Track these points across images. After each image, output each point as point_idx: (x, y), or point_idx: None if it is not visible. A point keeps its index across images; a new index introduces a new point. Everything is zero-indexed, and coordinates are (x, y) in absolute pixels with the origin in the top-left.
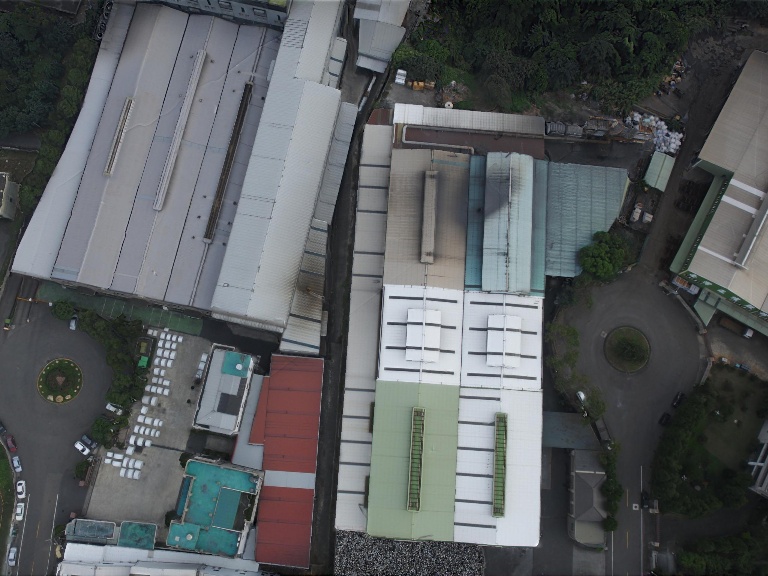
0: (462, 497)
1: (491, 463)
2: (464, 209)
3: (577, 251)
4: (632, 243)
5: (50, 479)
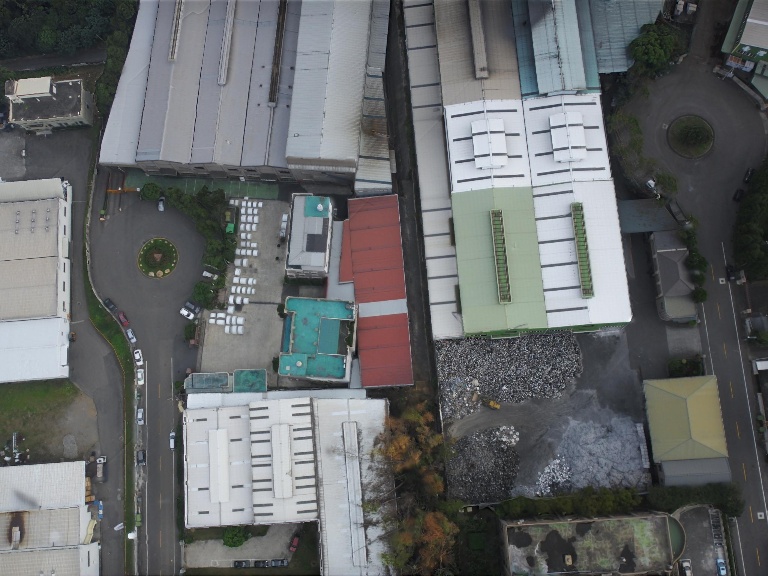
0: (550, 286)
1: (573, 251)
2: (510, 25)
3: (626, 46)
4: (680, 34)
5: (163, 345)
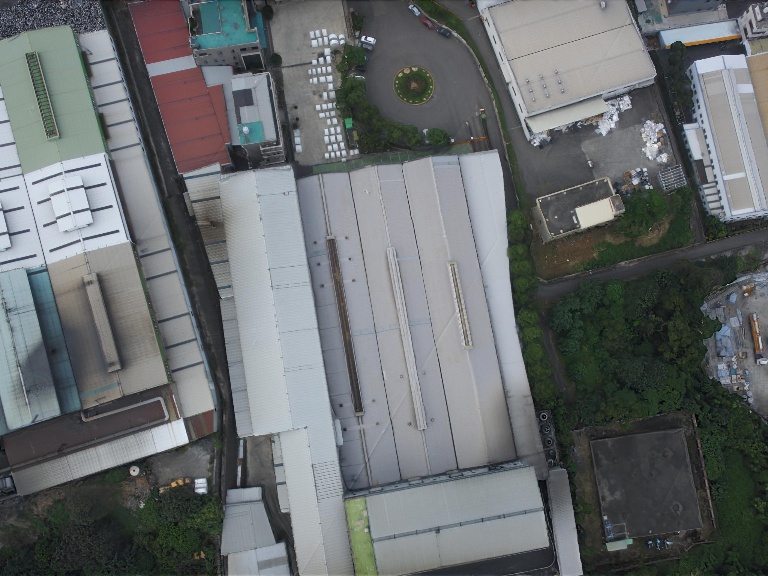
0: None
1: None
2: (71, 347)
3: None
4: None
5: (383, 9)
